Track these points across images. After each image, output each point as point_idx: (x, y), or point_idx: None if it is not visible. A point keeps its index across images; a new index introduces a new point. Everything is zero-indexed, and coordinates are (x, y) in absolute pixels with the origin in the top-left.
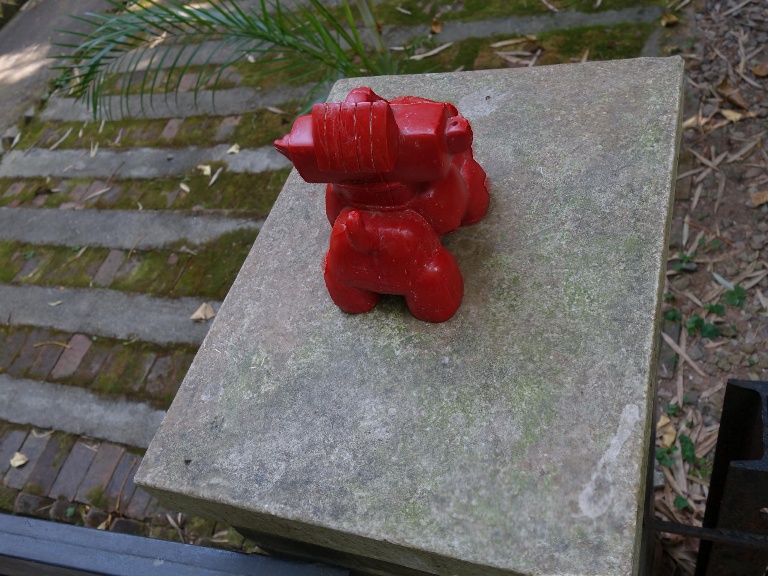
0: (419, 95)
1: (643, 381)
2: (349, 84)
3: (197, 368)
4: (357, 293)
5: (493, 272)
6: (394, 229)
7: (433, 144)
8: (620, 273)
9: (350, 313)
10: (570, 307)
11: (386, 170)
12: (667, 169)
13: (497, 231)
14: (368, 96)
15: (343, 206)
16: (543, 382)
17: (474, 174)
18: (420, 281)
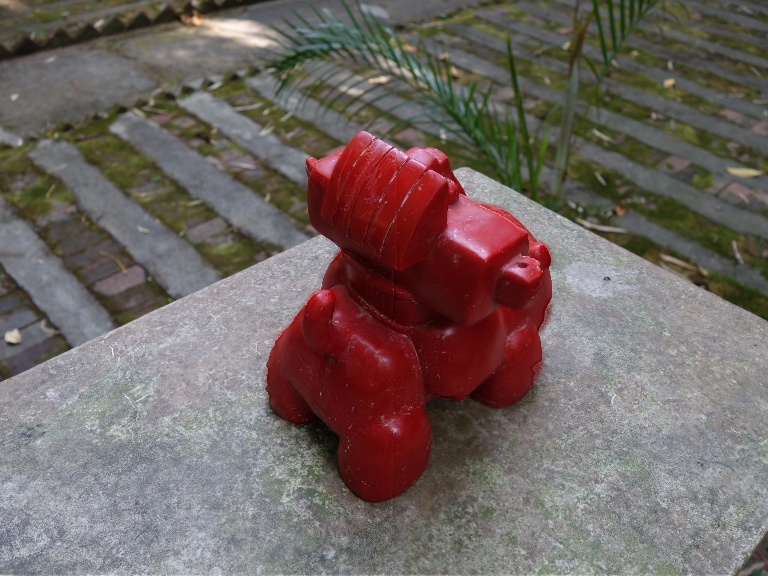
0: (535, 230)
1: None
2: (473, 177)
3: (77, 355)
4: (292, 394)
5: (469, 481)
6: (372, 347)
7: (476, 272)
8: None
9: (275, 411)
10: None
11: (394, 265)
12: None
13: (511, 434)
14: (436, 164)
15: (340, 282)
16: None
17: (525, 348)
18: (364, 432)
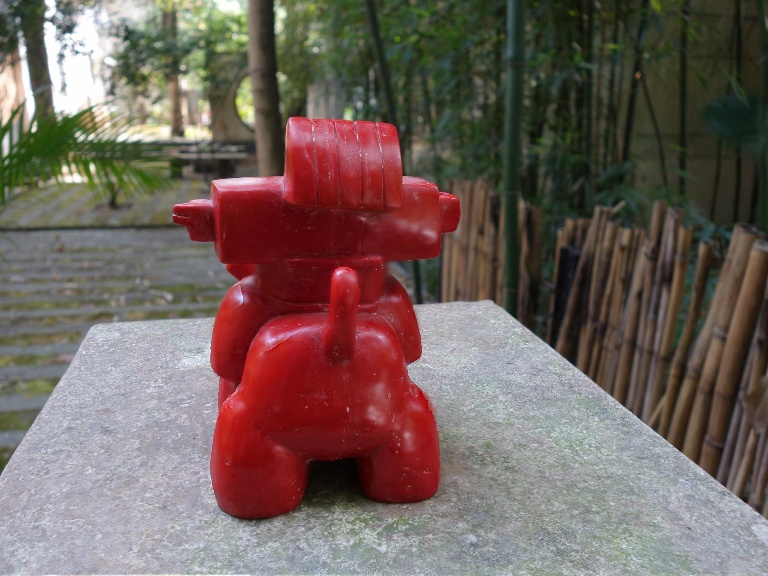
0: None
1: (738, 501)
2: (116, 326)
3: None
4: (289, 461)
5: (452, 443)
6: None
7: (435, 198)
8: (600, 423)
9: (260, 517)
10: (580, 456)
11: (397, 205)
12: (557, 355)
13: None
14: None
15: (267, 317)
16: (632, 529)
17: None
18: (407, 413)
